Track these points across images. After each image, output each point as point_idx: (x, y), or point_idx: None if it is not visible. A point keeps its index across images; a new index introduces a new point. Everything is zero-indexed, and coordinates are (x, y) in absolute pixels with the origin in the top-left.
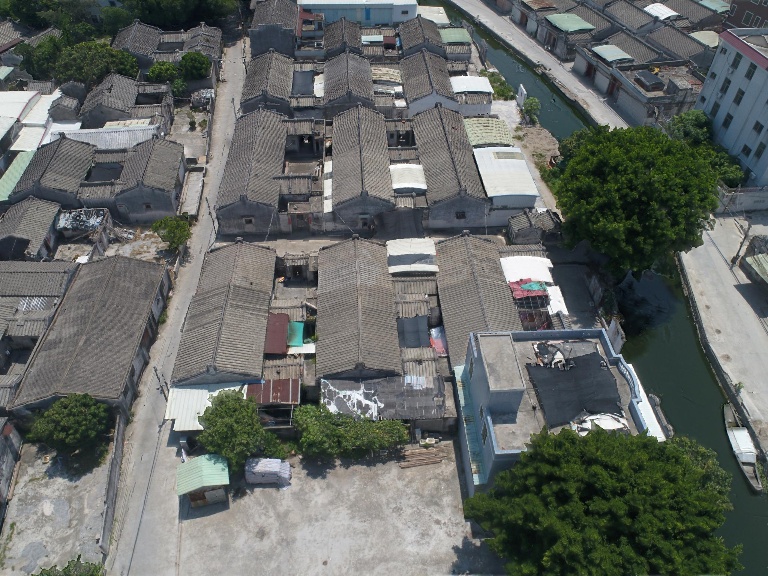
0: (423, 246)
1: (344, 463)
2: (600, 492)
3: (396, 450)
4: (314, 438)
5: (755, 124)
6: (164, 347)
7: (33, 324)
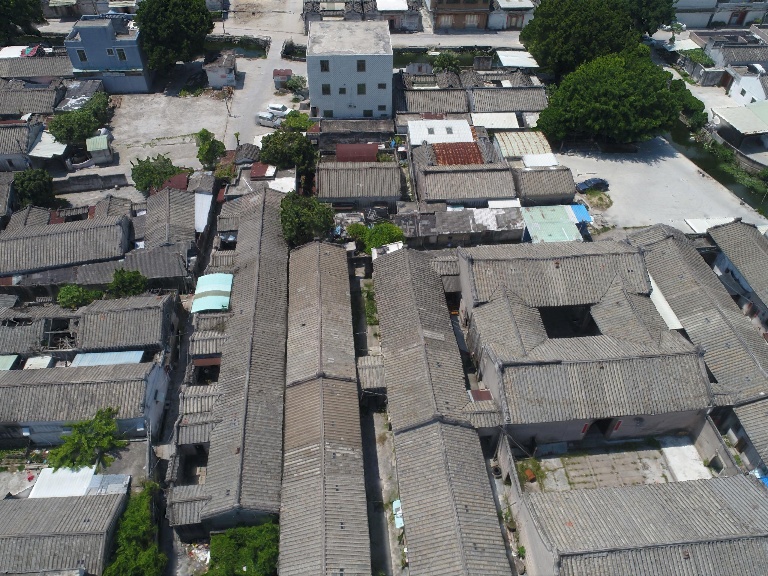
0: None
1: (108, 122)
2: (166, 5)
3: (108, 109)
4: (95, 106)
5: None
6: None
7: None
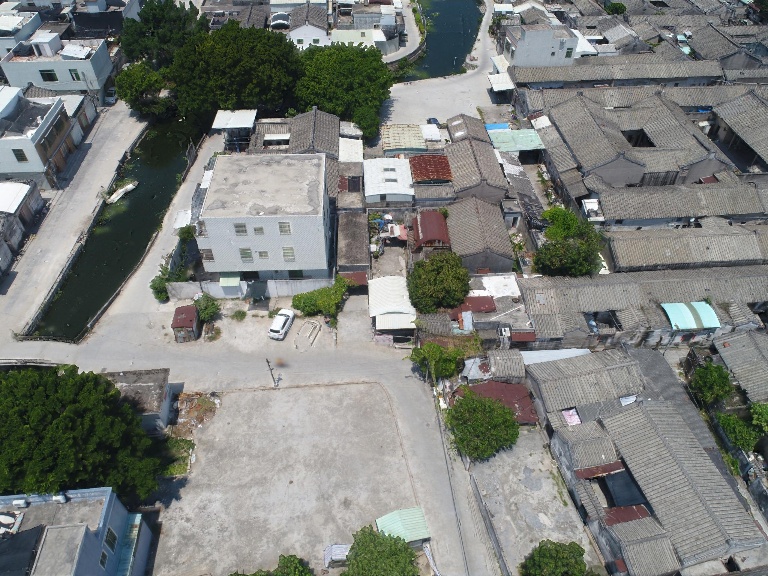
0: None
1: None
2: None
3: None
4: (293, 559)
5: None
6: None
7: None
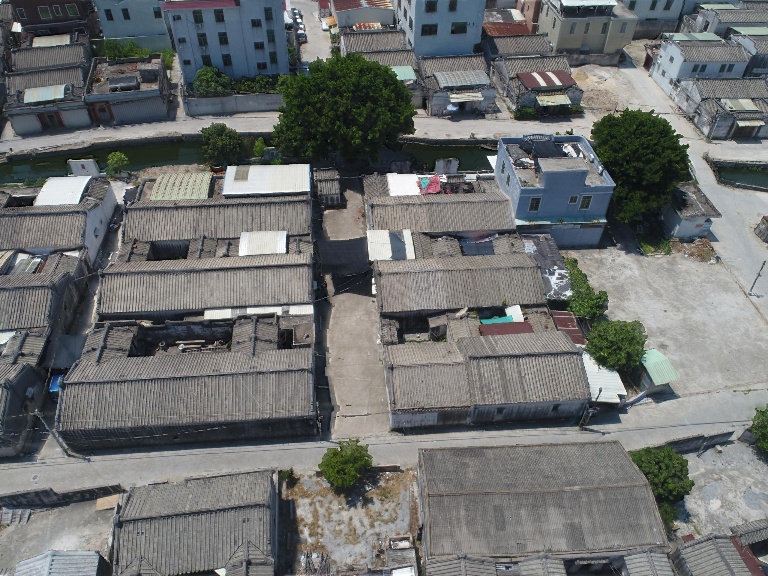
0: (378, 236)
1: None
2: None
3: None
4: (606, 295)
5: (254, 45)
6: None
7: (553, 573)
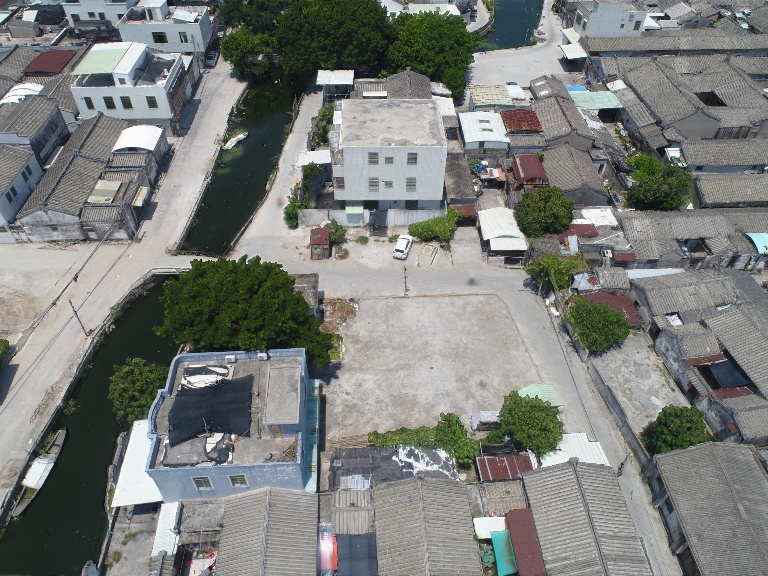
0: None
1: None
2: None
3: None
4: None
5: None
6: (667, 573)
7: None
